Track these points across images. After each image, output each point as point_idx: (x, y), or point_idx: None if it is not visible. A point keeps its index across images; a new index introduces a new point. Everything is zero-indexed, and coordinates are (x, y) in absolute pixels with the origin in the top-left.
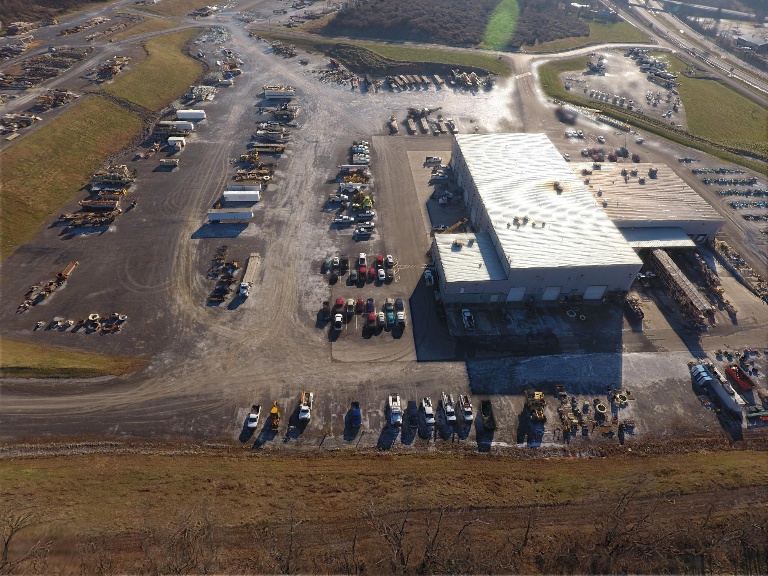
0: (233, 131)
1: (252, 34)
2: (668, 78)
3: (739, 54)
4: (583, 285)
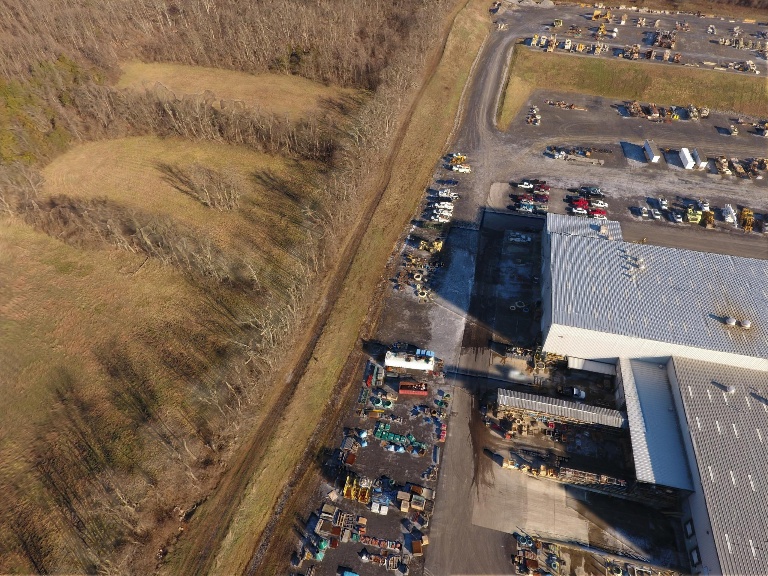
0: None
1: None
2: None
3: None
4: None
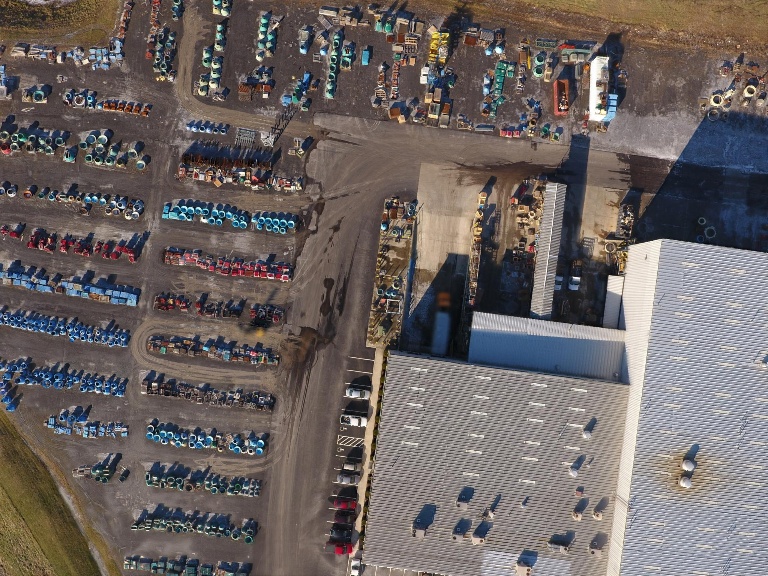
0: None
1: None
2: None
3: None
4: None
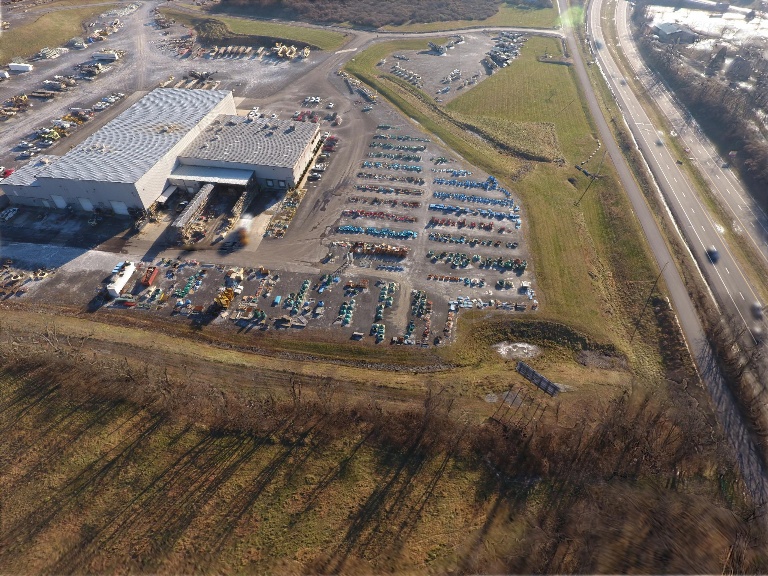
0: (38, 81)
1: (154, 10)
2: (502, 60)
3: (640, 42)
4: (104, 199)
